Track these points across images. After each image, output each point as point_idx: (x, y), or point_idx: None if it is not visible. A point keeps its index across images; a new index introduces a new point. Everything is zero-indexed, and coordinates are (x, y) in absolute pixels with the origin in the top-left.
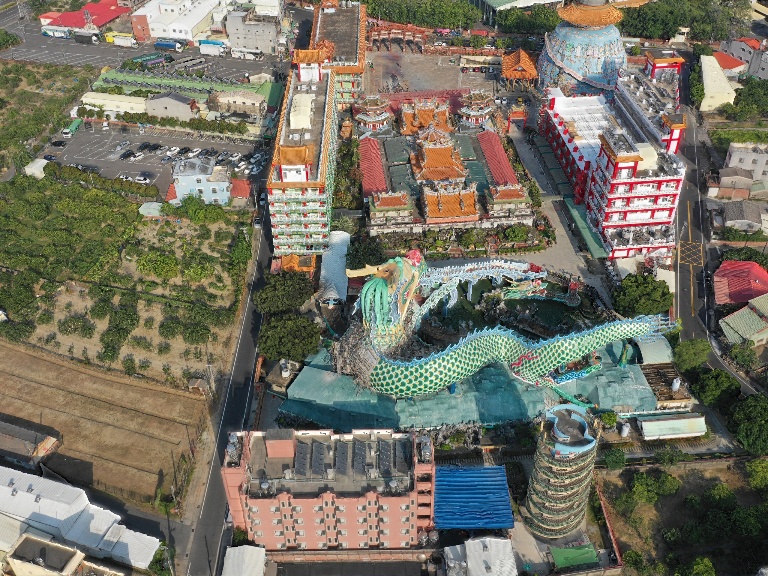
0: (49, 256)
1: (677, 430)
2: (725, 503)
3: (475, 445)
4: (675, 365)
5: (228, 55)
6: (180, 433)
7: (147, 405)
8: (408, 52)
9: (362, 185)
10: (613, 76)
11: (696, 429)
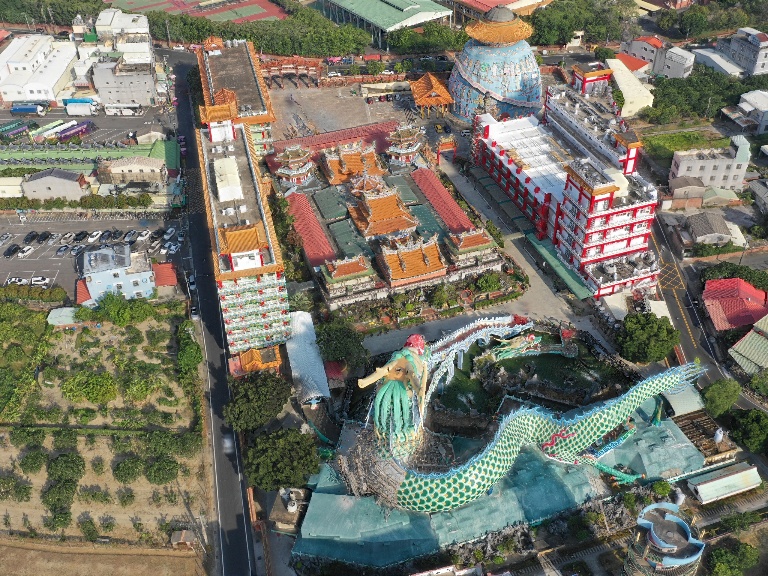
0: None
1: (733, 487)
2: None
3: (528, 550)
4: (707, 412)
5: (101, 113)
6: None
7: None
8: (303, 87)
9: (304, 251)
10: (532, 92)
11: (751, 482)
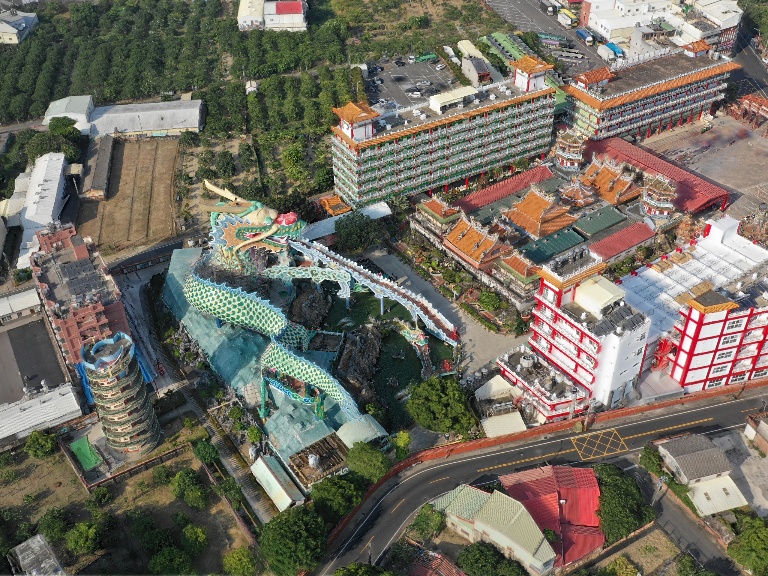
0: None
1: (269, 487)
2: (184, 541)
3: None
4: None
5: None
6: (138, 237)
7: (156, 214)
8: None
9: None
10: None
11: (279, 501)
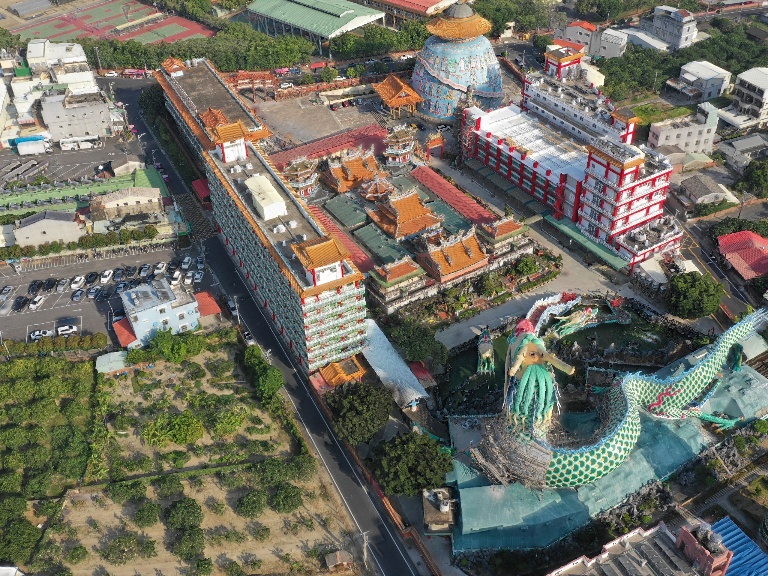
0: (17, 468)
1: None
2: None
3: (667, 505)
4: None
5: (55, 149)
6: None
7: None
8: (259, 101)
9: None
10: (496, 83)
11: None
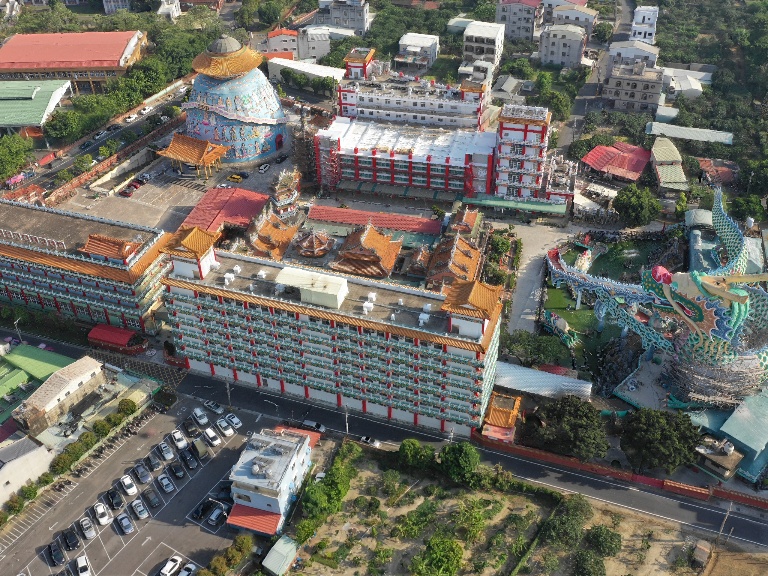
0: None
1: None
2: None
3: None
4: None
5: None
6: None
7: None
8: None
9: None
10: None
11: None
